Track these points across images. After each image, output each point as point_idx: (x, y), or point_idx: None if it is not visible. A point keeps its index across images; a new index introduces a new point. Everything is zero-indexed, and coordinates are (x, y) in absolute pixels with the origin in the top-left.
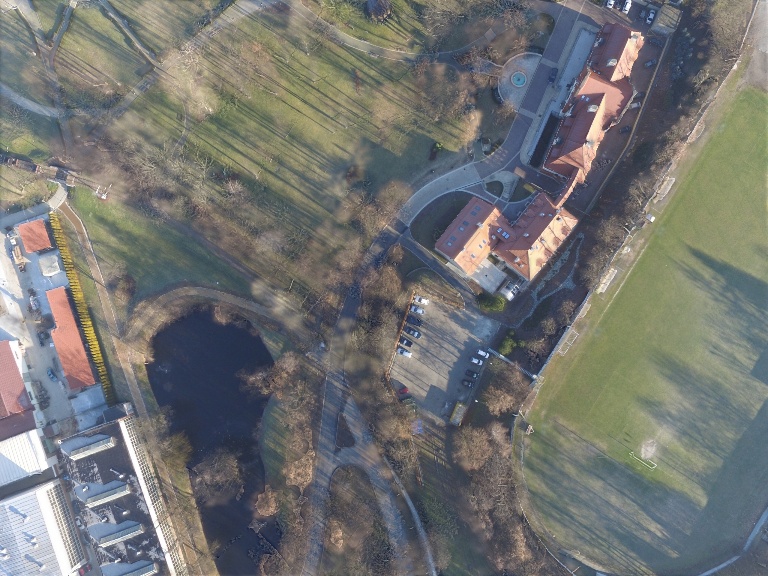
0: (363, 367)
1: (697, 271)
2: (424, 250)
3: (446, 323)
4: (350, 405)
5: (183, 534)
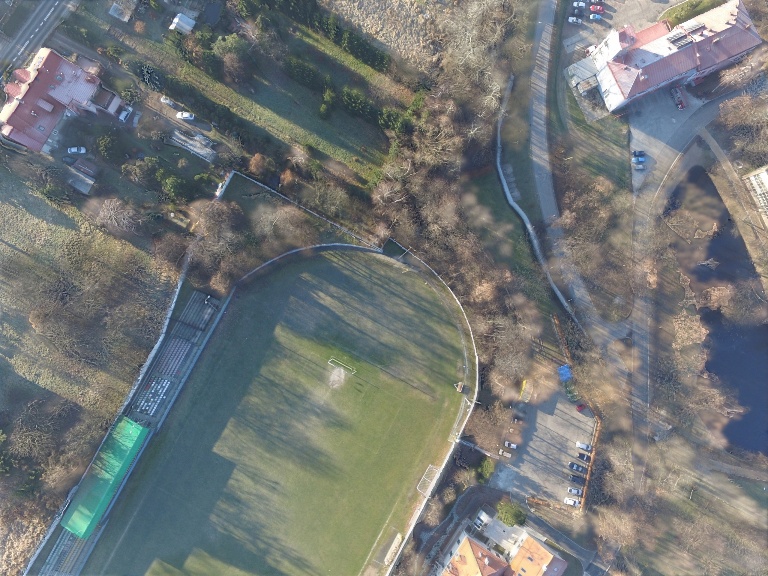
0: (618, 423)
1: (297, 568)
2: (569, 550)
3: (544, 480)
4: (622, 381)
5: (765, 239)
